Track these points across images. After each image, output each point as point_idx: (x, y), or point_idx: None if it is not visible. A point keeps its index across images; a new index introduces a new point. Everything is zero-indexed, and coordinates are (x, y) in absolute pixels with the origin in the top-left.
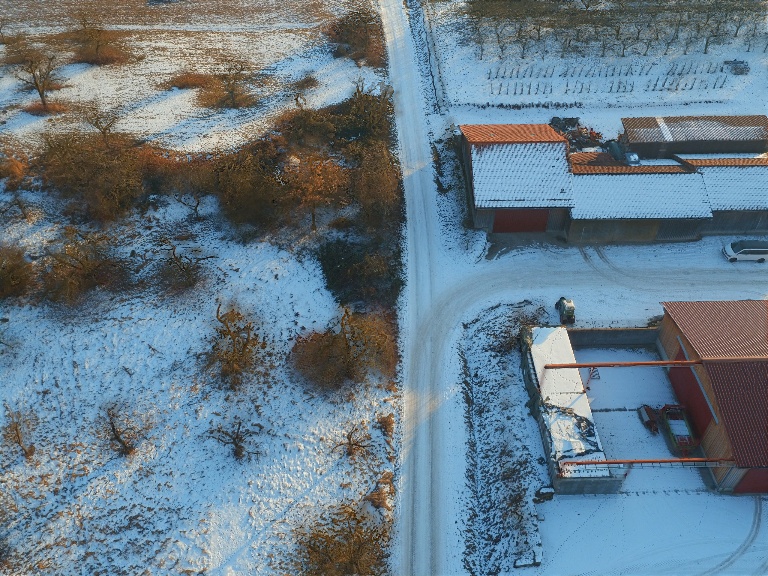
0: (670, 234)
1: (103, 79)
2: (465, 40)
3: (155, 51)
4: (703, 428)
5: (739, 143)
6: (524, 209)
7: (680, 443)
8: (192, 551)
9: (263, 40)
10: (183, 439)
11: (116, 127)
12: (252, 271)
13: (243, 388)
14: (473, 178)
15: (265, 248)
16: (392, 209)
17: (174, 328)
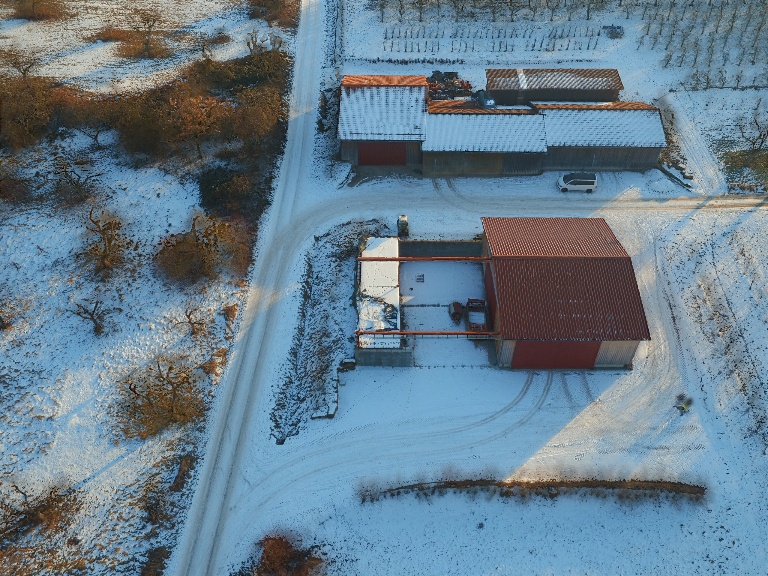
0: (514, 168)
1: (37, 32)
2: (372, 5)
3: (88, 10)
4: (494, 316)
5: (588, 92)
6: (380, 142)
7: (474, 329)
8: (46, 402)
9: (189, 3)
10: (54, 319)
11: (40, 72)
12: (138, 190)
13: (112, 280)
14: (339, 115)
15: (153, 172)
16: (263, 139)
17: (62, 233)
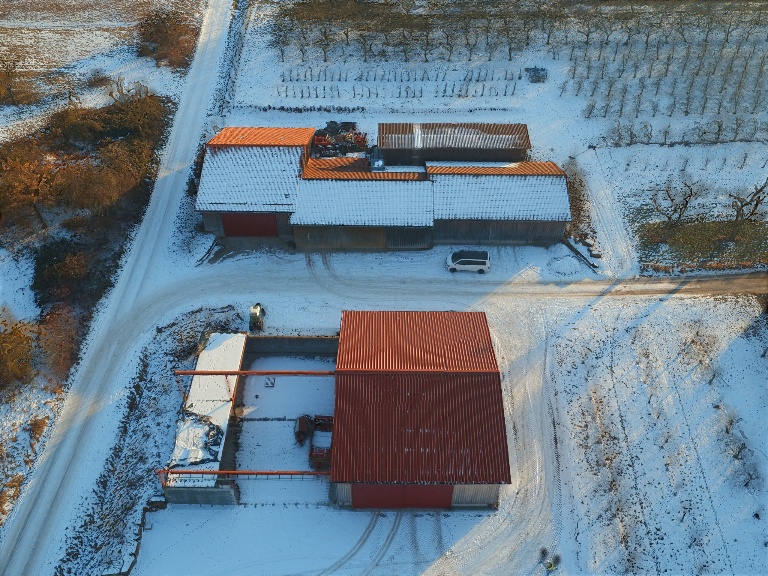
0: (400, 242)
1: None
2: (275, 42)
3: None
4: None
5: (492, 151)
6: (243, 213)
7: (316, 455)
8: None
9: (75, 38)
10: None
11: None
12: None
13: None
14: (200, 180)
15: None
16: (107, 210)
17: None
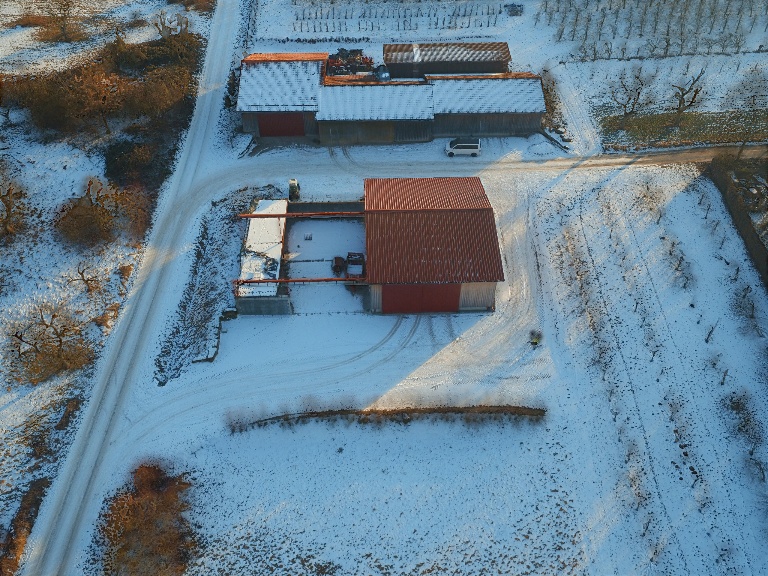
0: (406, 136)
1: None
2: None
3: None
4: None
5: (479, 64)
6: (277, 113)
7: None
8: None
9: None
10: None
11: None
12: (45, 163)
13: (14, 245)
14: (239, 89)
15: (62, 147)
16: (164, 112)
17: None
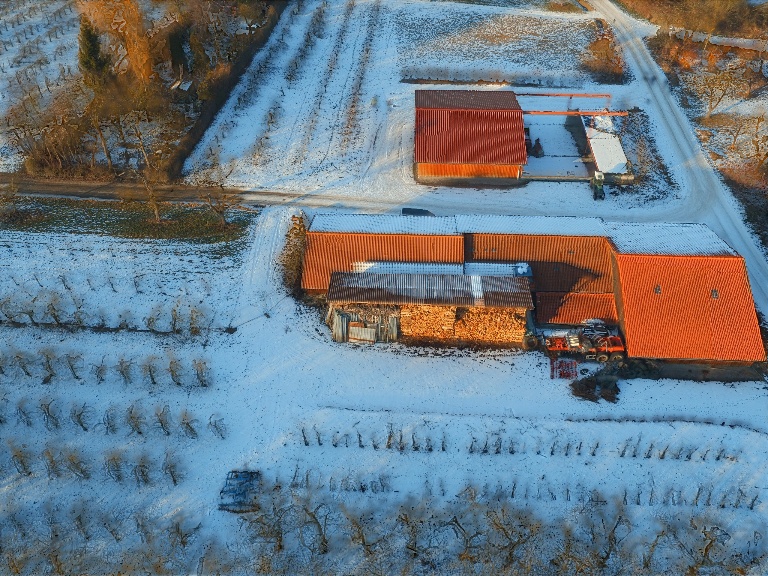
0: None
1: None
2: None
3: None
4: None
5: None
6: None
7: (525, 132)
8: None
9: None
10: None
11: None
12: None
13: None
14: None
15: None
16: None
17: None
